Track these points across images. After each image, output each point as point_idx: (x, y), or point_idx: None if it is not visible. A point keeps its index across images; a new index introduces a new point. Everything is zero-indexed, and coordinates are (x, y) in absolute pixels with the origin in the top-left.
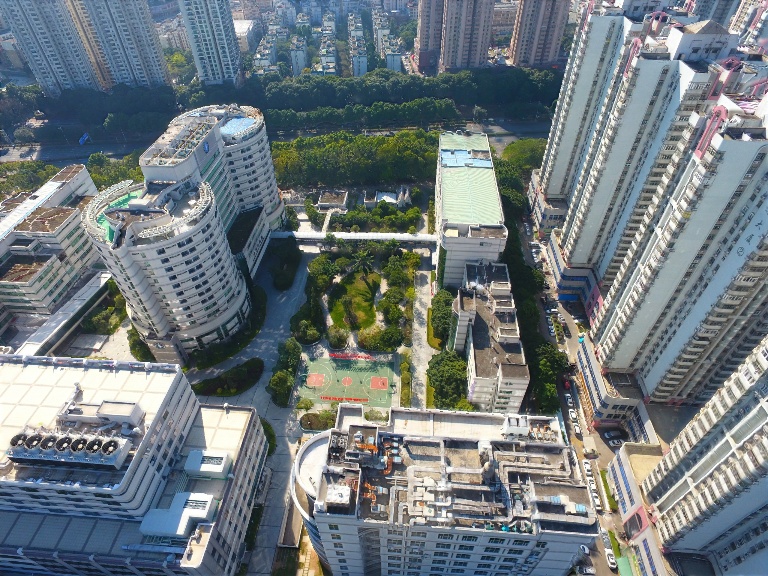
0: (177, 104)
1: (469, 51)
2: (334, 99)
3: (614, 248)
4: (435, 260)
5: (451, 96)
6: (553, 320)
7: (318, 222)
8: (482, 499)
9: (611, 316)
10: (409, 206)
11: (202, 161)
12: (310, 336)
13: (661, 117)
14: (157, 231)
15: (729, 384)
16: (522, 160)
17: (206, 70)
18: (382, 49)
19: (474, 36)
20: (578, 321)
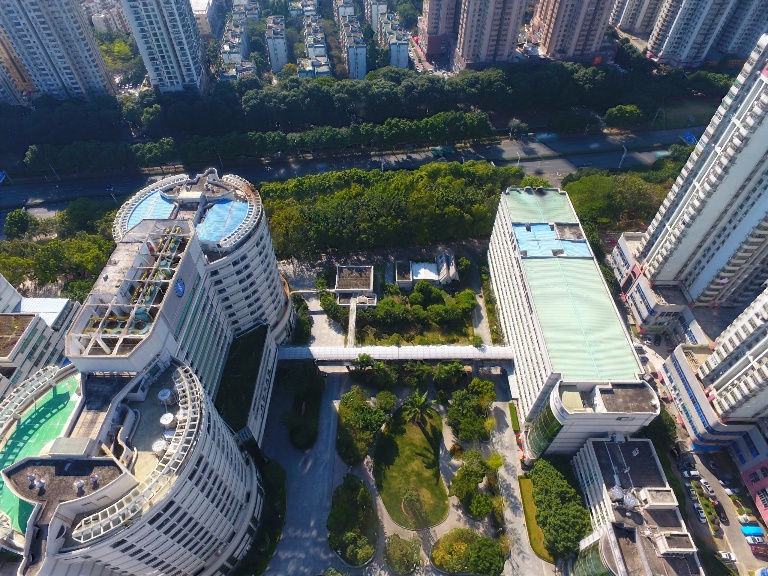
0: (124, 119)
1: (497, 41)
2: (332, 111)
3: None
4: (515, 390)
5: (478, 102)
6: (698, 492)
7: (337, 315)
8: None
9: None
10: (455, 282)
11: (175, 315)
12: (362, 559)
13: None
14: (107, 520)
15: None
16: (596, 210)
17: (160, 73)
18: (381, 33)
19: (504, 22)
20: (732, 492)
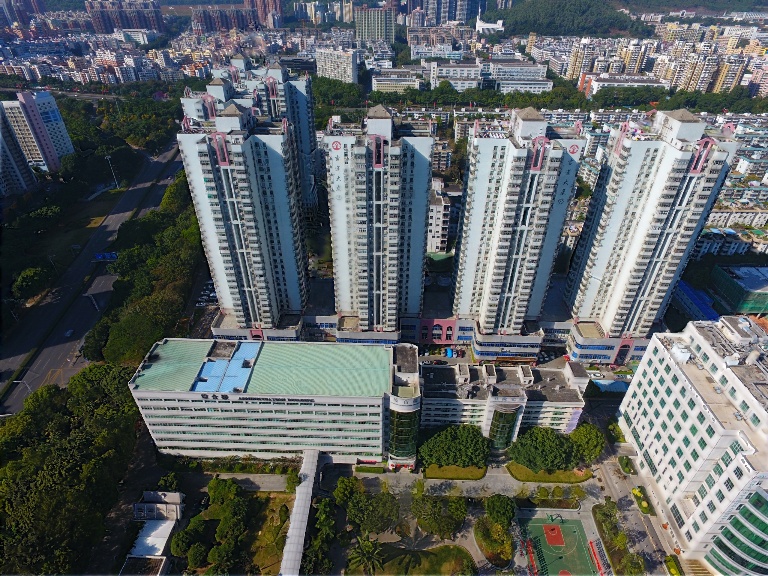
0: None
1: None
2: None
3: (421, 285)
4: (350, 459)
5: None
6: None
7: None
8: (767, 367)
9: (502, 304)
10: (185, 502)
11: None
12: None
13: (410, 180)
14: None
15: (598, 256)
16: None
17: None
18: None
19: None
20: (427, 353)
